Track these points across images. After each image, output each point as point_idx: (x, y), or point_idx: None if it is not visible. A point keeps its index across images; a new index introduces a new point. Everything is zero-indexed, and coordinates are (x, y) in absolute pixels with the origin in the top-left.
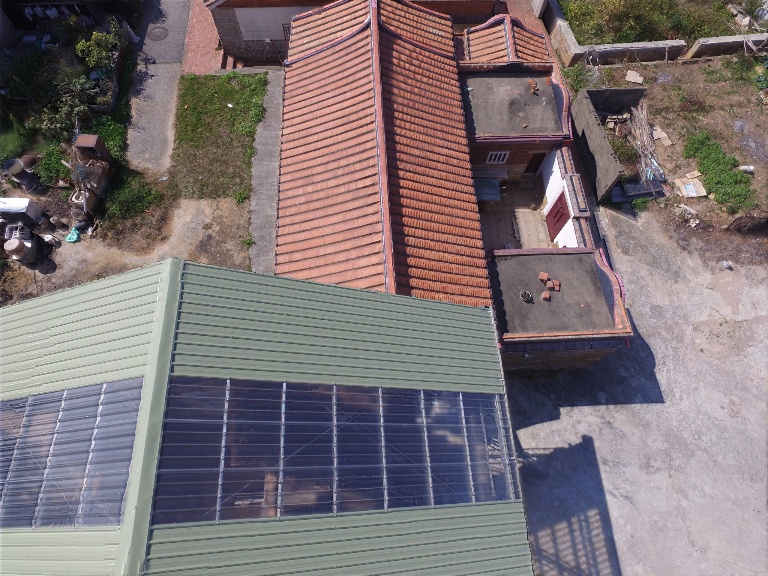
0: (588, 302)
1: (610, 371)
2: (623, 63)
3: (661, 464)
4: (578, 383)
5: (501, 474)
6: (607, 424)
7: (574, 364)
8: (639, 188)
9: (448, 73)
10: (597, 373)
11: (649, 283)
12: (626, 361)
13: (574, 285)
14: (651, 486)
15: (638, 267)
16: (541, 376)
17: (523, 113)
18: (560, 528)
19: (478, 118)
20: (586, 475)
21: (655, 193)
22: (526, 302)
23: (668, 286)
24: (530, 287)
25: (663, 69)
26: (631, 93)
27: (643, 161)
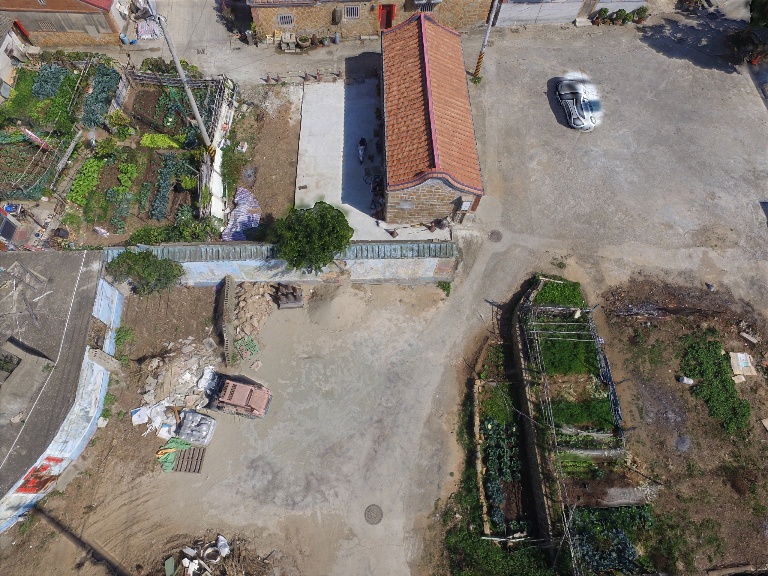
0: None
1: None
2: None
3: (760, 174)
4: None
5: None
6: None
7: None
8: None
9: None
10: None
11: None
12: None
13: None
14: (766, 165)
15: None
16: None
17: None
18: None
19: None
20: None
21: None
22: None
23: (760, 274)
24: None
25: None
26: None
27: None
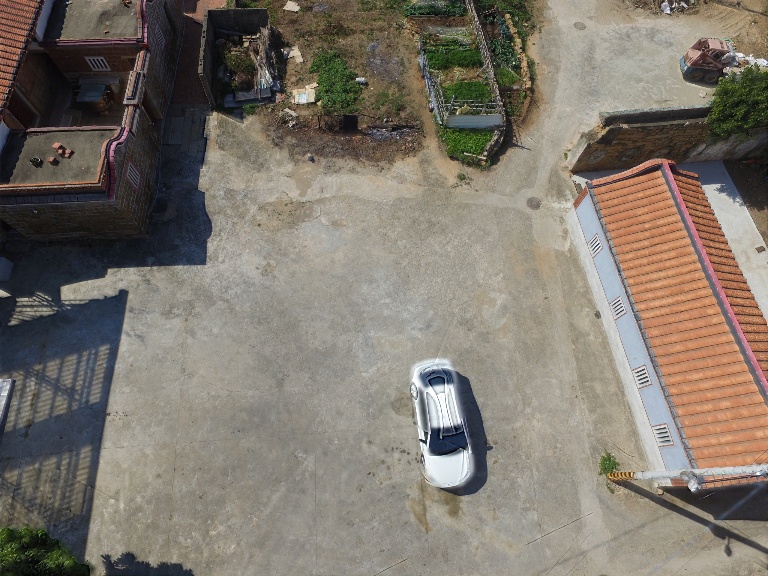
0: (90, 166)
1: (166, 241)
2: None
3: (182, 311)
4: (133, 250)
5: (33, 320)
6: (146, 281)
7: (124, 232)
8: (249, 95)
9: None
10: (153, 242)
11: (233, 172)
12: (184, 233)
13: (85, 153)
14: (166, 328)
15: (228, 160)
16: (100, 244)
17: (110, 22)
18: (69, 360)
19: (67, 26)
20: (111, 320)
21: (264, 99)
22: (35, 166)
23: (249, 175)
24: (46, 155)
25: None
26: (255, 14)
27: (259, 73)
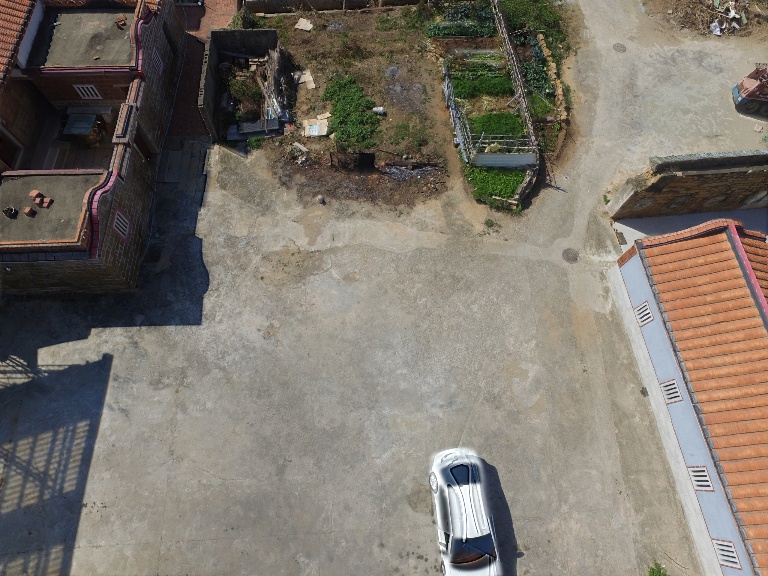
0: (70, 218)
1: (158, 296)
2: (299, 11)
3: (173, 381)
4: (120, 306)
5: (5, 388)
6: (133, 344)
7: (110, 287)
8: (254, 126)
9: (14, 5)
10: (143, 297)
11: (234, 215)
12: (178, 287)
13: (66, 203)
14: (153, 400)
15: (229, 201)
16: (84, 299)
17: (101, 46)
18: (44, 437)
19: (54, 51)
20: (92, 390)
21: (271, 132)
22: (9, 217)
23: (252, 218)
24: (21, 204)
25: (338, 17)
26: (263, 35)
27: (266, 101)
